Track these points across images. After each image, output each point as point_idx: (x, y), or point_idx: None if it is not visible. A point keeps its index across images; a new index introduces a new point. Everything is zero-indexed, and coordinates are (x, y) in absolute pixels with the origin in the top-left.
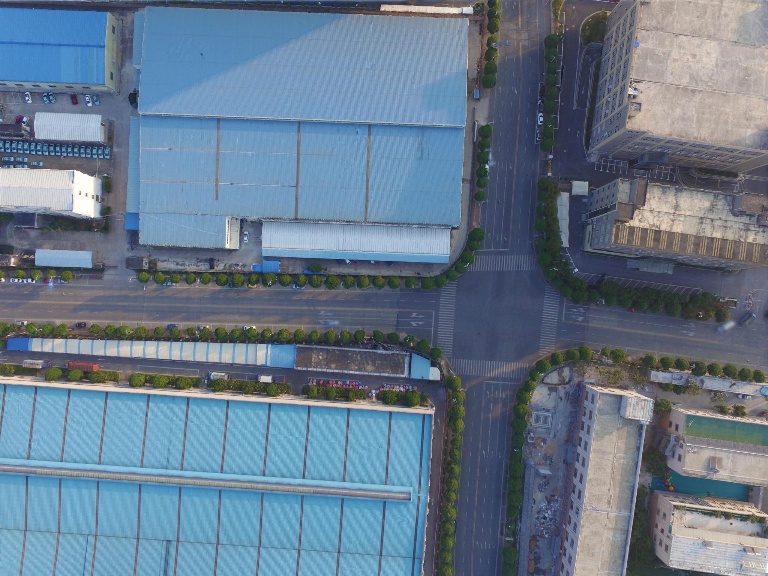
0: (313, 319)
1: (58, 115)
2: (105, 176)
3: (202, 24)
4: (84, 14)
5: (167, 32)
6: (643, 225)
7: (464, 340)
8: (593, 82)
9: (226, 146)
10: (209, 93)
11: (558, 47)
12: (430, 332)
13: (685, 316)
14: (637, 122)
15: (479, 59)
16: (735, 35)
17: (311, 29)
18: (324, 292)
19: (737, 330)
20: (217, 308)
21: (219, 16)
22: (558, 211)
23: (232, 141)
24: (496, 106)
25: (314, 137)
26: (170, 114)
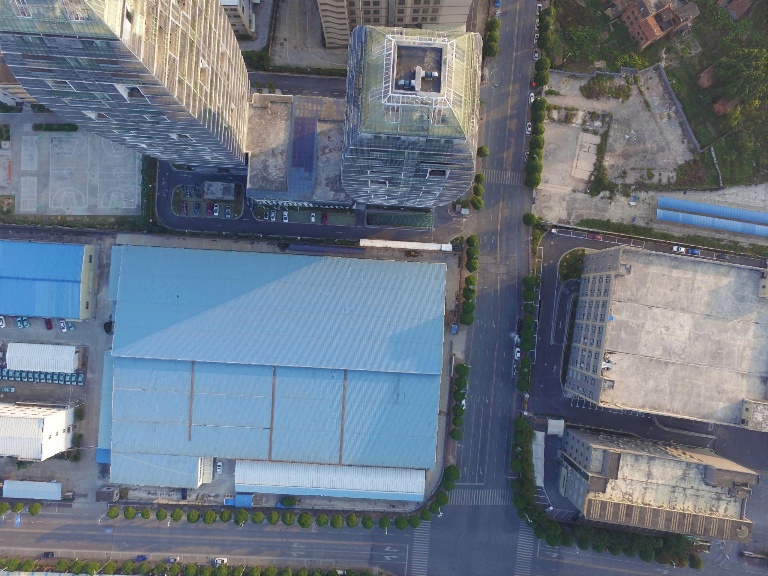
0: (286, 551)
1: (31, 346)
2: (78, 403)
3: (179, 265)
4: (61, 247)
5: (144, 272)
6: (616, 493)
7: (438, 575)
8: (570, 319)
9: (200, 388)
10: (184, 337)
11: None
12: (404, 566)
13: (659, 561)
14: (610, 393)
15: (457, 292)
16: (708, 308)
17: (289, 272)
18: (297, 524)
19: (711, 568)
20: (188, 539)
21: (197, 257)
22: (533, 451)
23: (207, 383)
24: (474, 339)
25: (289, 381)
26: (144, 357)
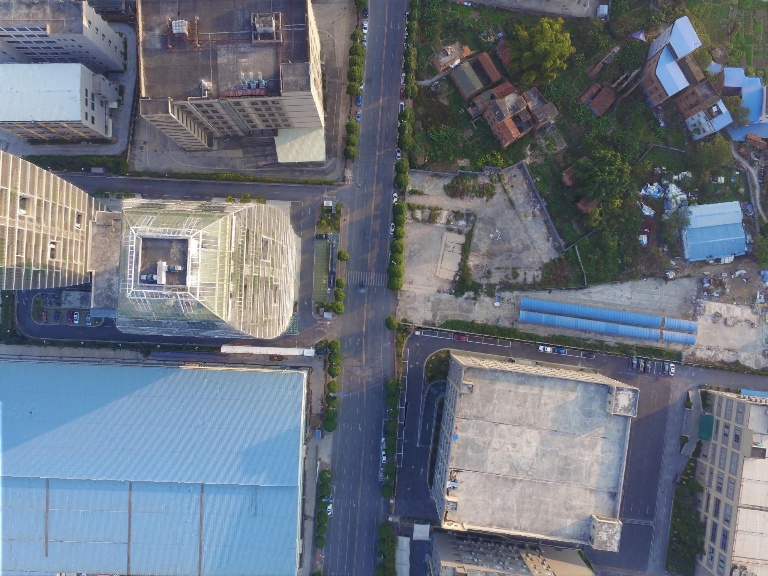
0: None
1: None
2: None
3: (32, 380)
4: None
5: None
6: None
7: None
8: (435, 422)
9: (56, 504)
10: (37, 454)
11: (402, 385)
12: None
13: None
14: (457, 512)
15: (323, 395)
16: (555, 424)
17: (144, 385)
18: None
19: None
20: None
21: (50, 371)
22: (398, 557)
23: (62, 499)
24: (340, 443)
25: (146, 495)
26: None
